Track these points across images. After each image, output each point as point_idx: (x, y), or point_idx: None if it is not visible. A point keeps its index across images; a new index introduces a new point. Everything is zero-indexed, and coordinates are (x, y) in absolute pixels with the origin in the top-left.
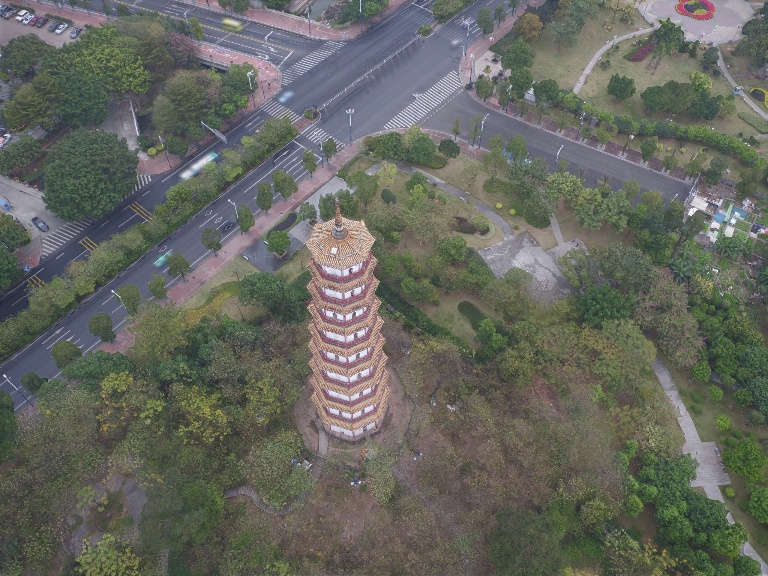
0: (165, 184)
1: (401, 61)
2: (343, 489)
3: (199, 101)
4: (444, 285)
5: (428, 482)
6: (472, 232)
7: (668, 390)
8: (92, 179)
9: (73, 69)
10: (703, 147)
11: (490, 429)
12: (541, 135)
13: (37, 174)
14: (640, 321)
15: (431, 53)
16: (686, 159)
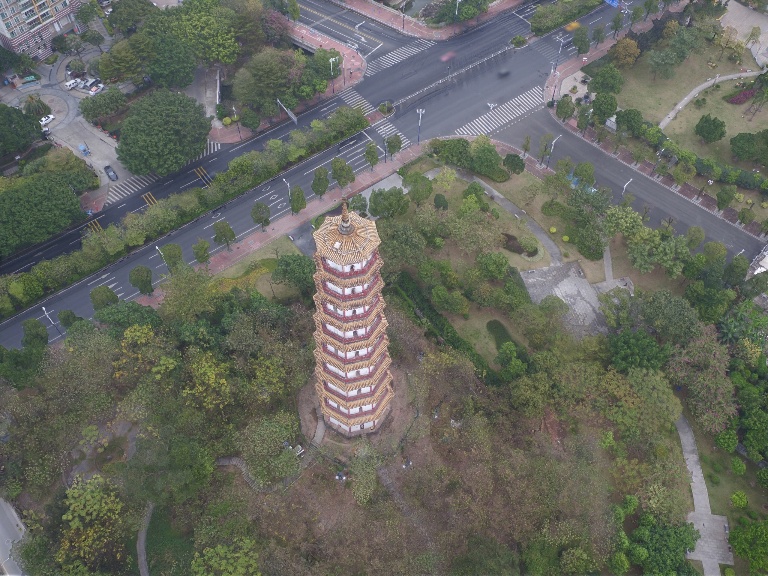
0: (232, 154)
1: (487, 69)
2: (328, 481)
3: (279, 79)
4: (476, 300)
5: (412, 492)
6: (519, 252)
7: (688, 452)
8: (163, 138)
9: (169, 32)
10: None
11: (484, 453)
12: (615, 165)
13: (118, 126)
14: (671, 375)
15: (520, 65)
16: (766, 215)
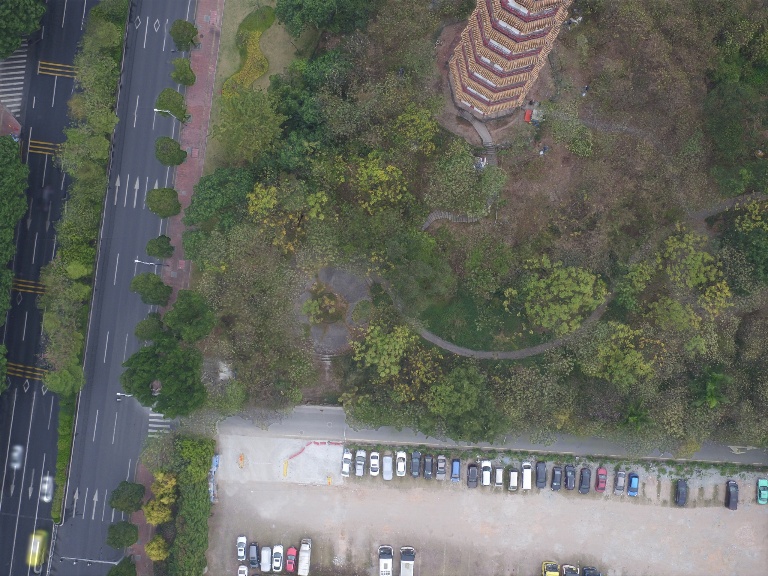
0: None
1: None
2: None
3: None
4: None
5: (607, 109)
6: None
7: None
8: None
9: None
10: None
11: None
12: None
13: None
14: None
15: None
16: None
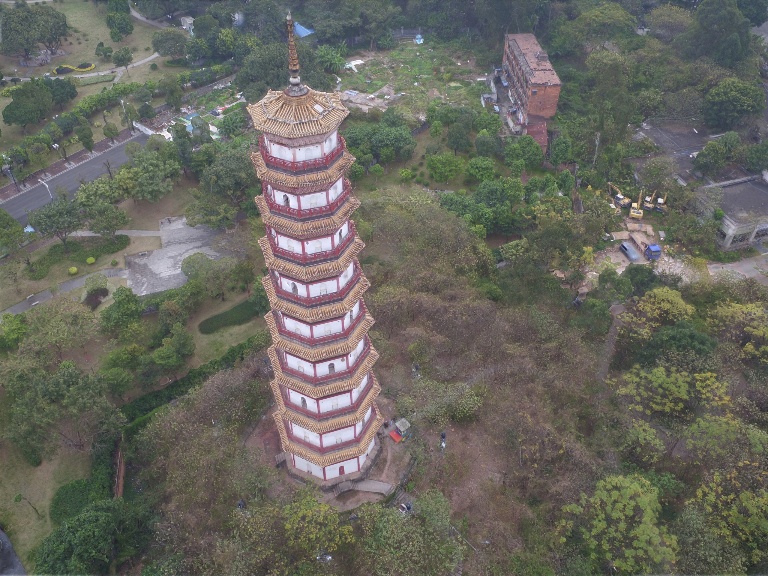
0: None
1: None
2: None
3: None
4: None
5: None
6: (97, 302)
7: None
8: None
9: None
10: (104, 111)
11: None
12: None
13: None
14: None
15: None
16: None
